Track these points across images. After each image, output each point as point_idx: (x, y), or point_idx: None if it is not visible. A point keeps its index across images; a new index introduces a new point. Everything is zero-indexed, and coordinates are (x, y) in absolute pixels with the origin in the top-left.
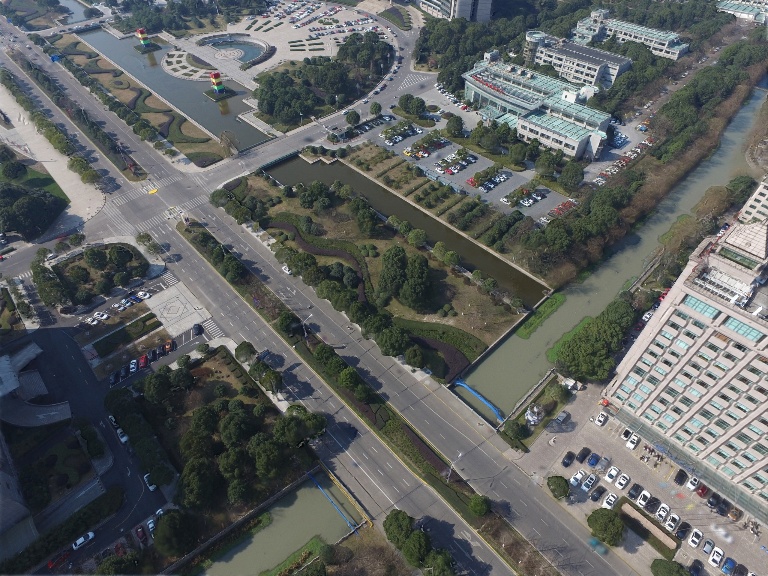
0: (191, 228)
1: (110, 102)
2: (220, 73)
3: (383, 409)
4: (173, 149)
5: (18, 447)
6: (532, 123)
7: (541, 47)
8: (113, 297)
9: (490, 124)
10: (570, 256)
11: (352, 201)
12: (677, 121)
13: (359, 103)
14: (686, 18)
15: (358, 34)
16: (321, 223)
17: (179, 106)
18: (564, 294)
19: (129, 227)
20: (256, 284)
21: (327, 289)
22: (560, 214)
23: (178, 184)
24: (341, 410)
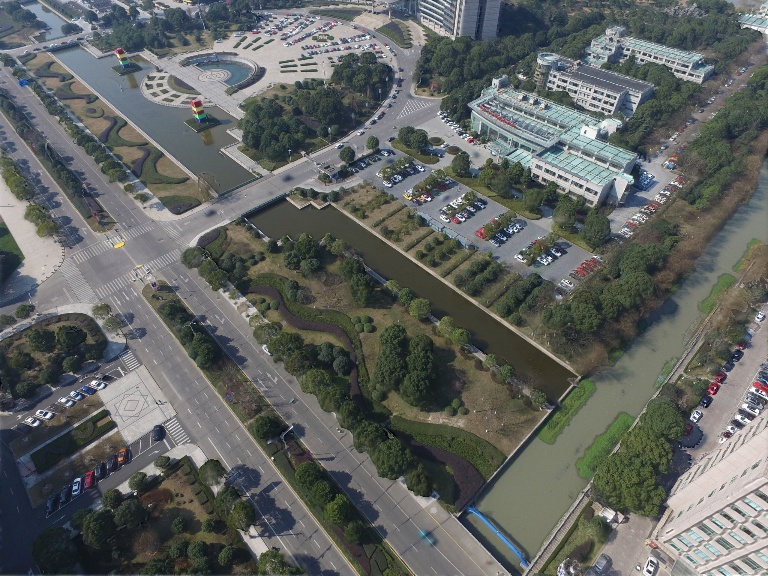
0: (159, 293)
1: (78, 135)
2: (203, 98)
3: (379, 552)
4: (145, 192)
5: None
6: (548, 163)
7: (554, 71)
8: (61, 387)
9: (500, 161)
10: (601, 337)
11: (345, 262)
12: (711, 160)
13: (354, 134)
14: (708, 35)
15: (354, 55)
16: (309, 287)
17: (156, 138)
18: (593, 381)
19: (88, 291)
20: (230, 373)
21: (313, 383)
22: (584, 275)
23: (148, 235)
24: (328, 552)
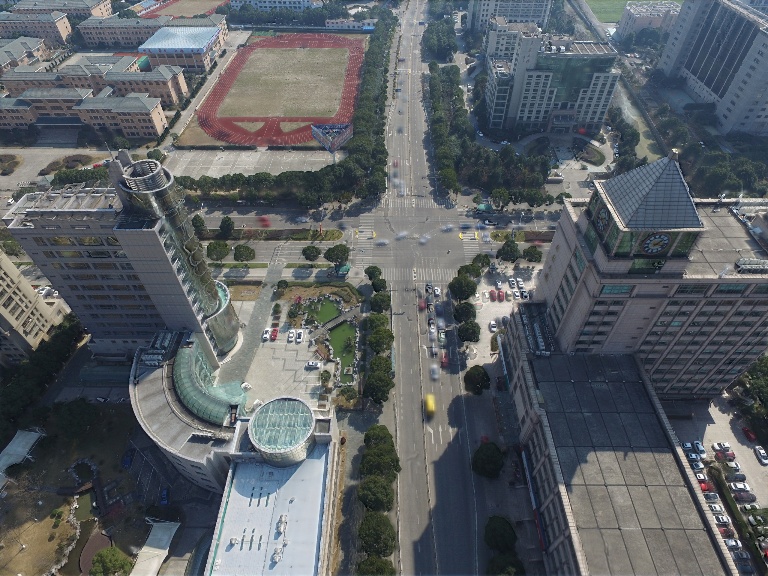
0: None
1: None
2: None
3: None
4: None
5: (767, 139)
6: None
7: None
8: None
9: None
10: None
11: None
12: None
13: None
14: None
15: None
16: None
17: None
18: None
19: None
20: None
21: None
22: None
23: None
24: None
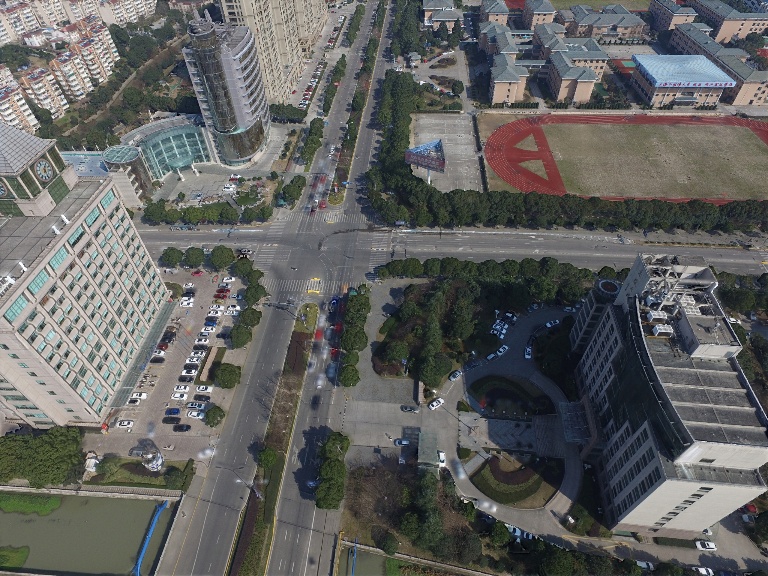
0: None
1: None
2: None
3: None
4: None
5: None
6: None
7: None
8: None
9: None
10: None
11: None
12: None
13: None
14: None
15: None
16: None
17: None
18: None
19: None
20: None
21: None
22: None
23: None
24: None
